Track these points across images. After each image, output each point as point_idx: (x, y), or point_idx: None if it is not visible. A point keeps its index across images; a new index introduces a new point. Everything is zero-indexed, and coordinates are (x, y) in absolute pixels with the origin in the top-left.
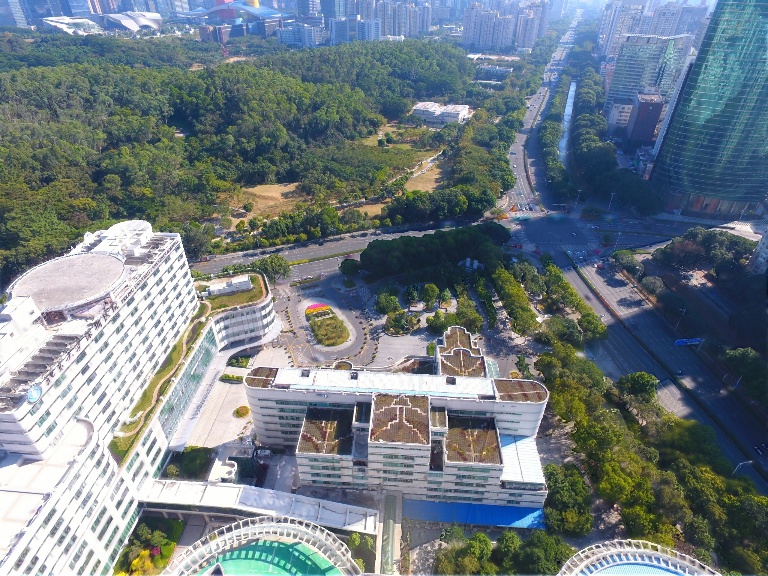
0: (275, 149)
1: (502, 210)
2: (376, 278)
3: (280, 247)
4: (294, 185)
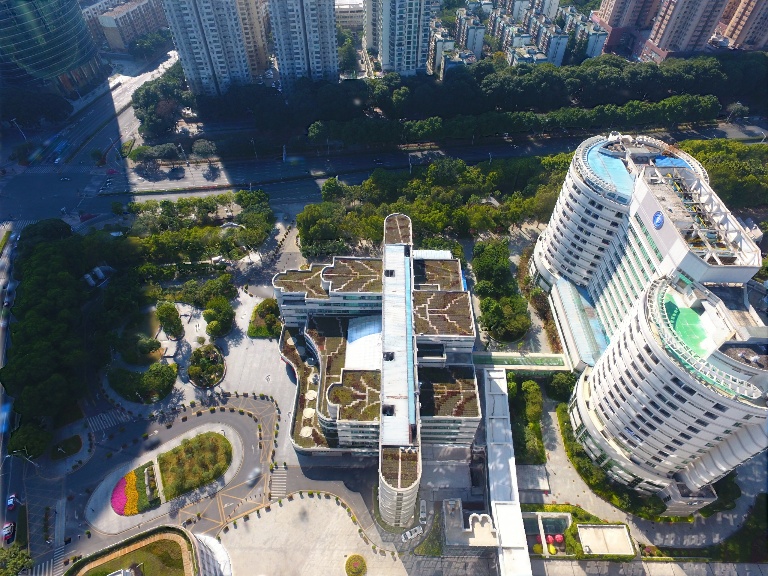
0: None
1: None
2: None
3: None
4: None
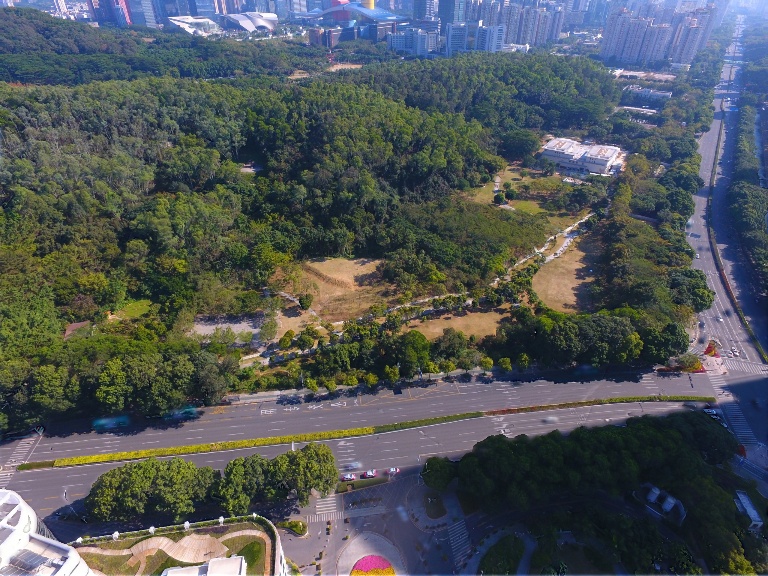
0: (357, 206)
1: (694, 353)
2: (483, 509)
3: (336, 389)
4: (374, 264)
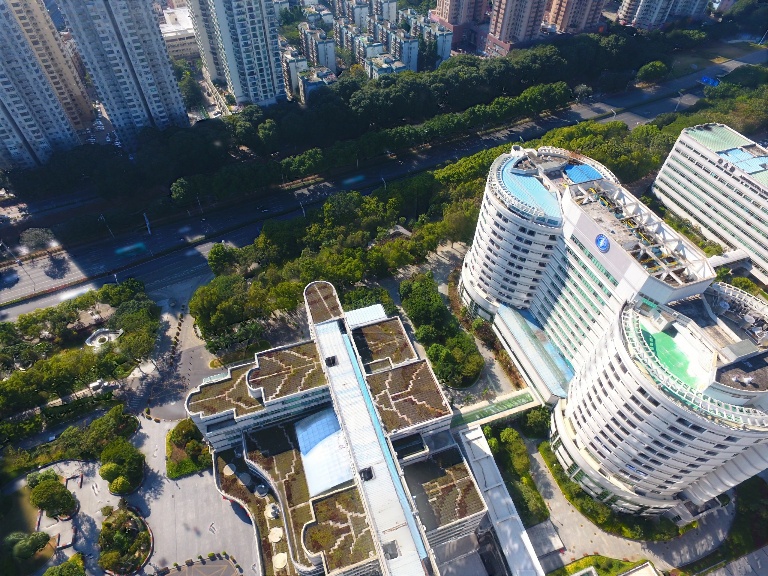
0: None
1: None
2: None
3: None
4: None
